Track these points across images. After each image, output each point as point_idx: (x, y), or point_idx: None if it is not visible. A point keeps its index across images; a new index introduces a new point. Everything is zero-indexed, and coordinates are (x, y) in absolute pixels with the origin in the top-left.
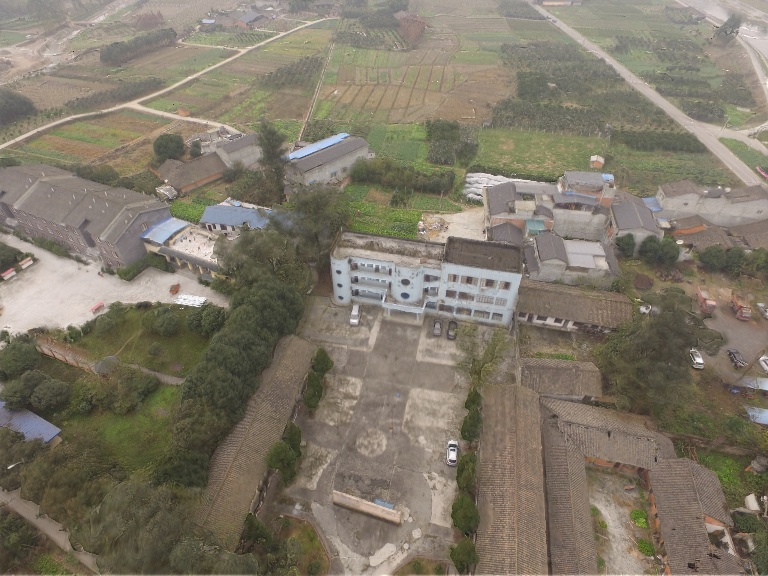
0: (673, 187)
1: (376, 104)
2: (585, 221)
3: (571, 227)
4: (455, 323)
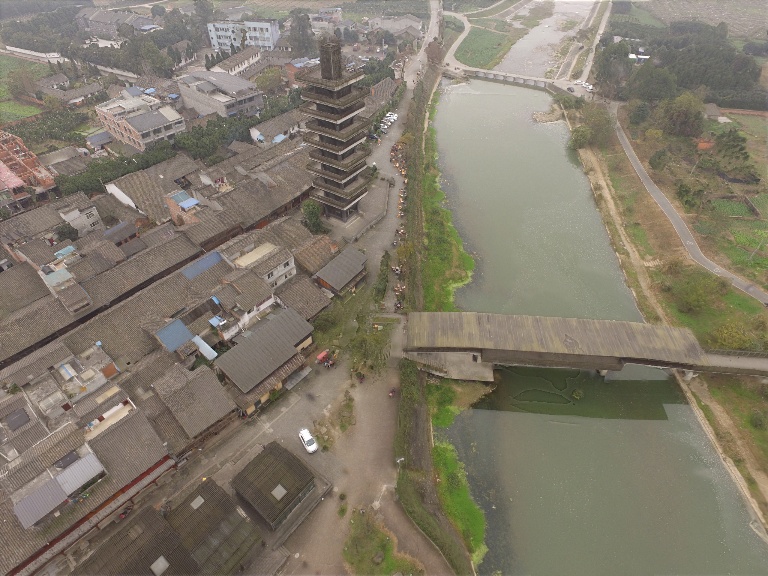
0: None
1: (276, 5)
2: (327, 27)
3: (323, 31)
4: None
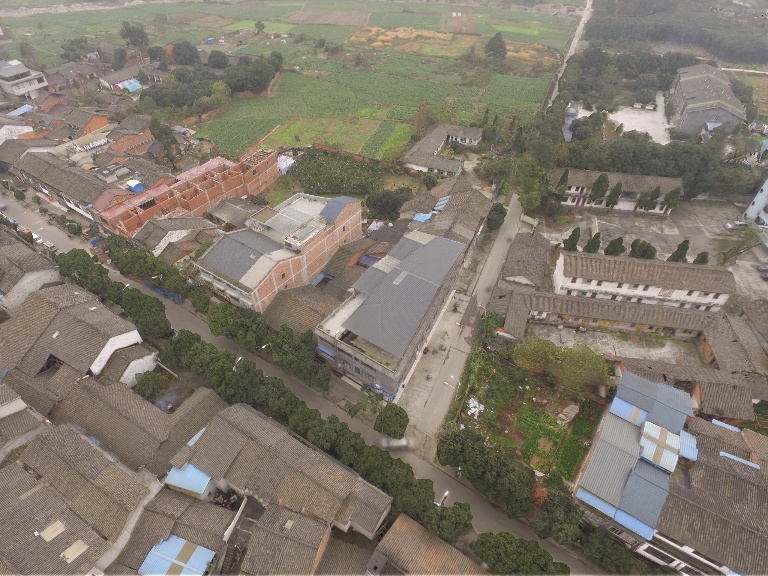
0: None
1: None
2: None
3: None
4: None
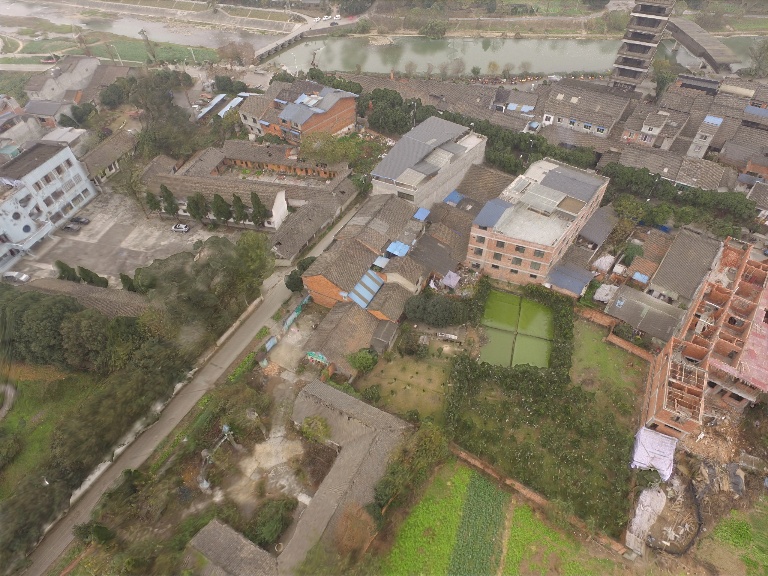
0: (32, 84)
1: None
2: (26, 131)
3: None
4: (74, 218)
